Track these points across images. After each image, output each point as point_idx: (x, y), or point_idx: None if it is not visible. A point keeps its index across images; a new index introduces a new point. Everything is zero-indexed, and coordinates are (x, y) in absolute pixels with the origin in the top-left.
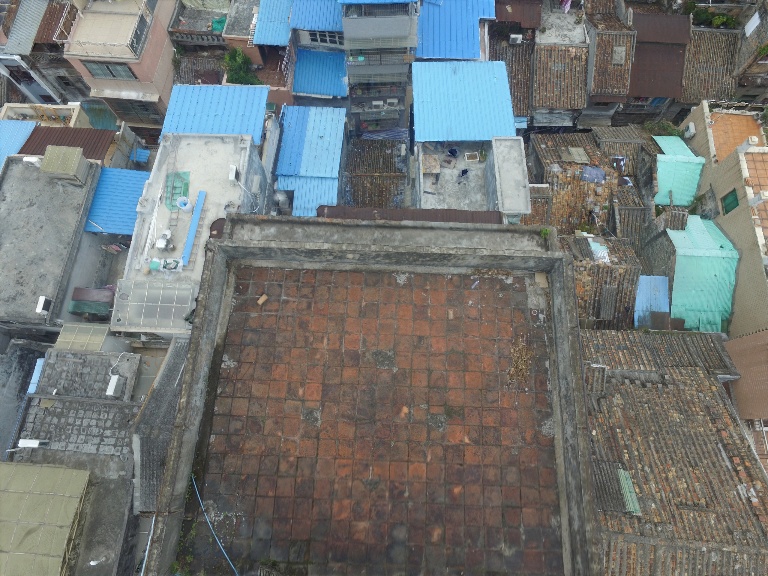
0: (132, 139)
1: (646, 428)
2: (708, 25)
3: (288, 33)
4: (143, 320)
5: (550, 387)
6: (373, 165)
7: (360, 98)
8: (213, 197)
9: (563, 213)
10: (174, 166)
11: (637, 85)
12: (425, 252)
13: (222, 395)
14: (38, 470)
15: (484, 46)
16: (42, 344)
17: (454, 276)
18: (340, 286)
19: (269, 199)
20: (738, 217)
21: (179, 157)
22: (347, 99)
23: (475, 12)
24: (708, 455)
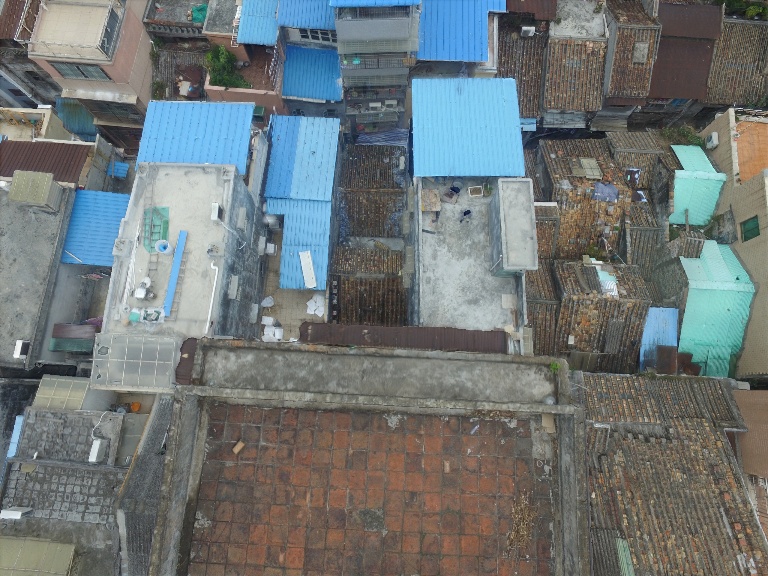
0: (109, 151)
1: (647, 490)
2: (741, 15)
3: (275, 30)
4: (124, 378)
5: (553, 554)
6: (370, 178)
7: (356, 100)
8: (195, 237)
9: (571, 233)
10: (152, 201)
11: (658, 85)
12: (419, 406)
13: (196, 560)
14: (21, 544)
15: (493, 44)
16: (25, 380)
17: (452, 419)
18: (325, 430)
19: (257, 224)
20: (758, 248)
21: (157, 190)
22: (342, 102)
23: (484, 4)
24: (709, 520)
